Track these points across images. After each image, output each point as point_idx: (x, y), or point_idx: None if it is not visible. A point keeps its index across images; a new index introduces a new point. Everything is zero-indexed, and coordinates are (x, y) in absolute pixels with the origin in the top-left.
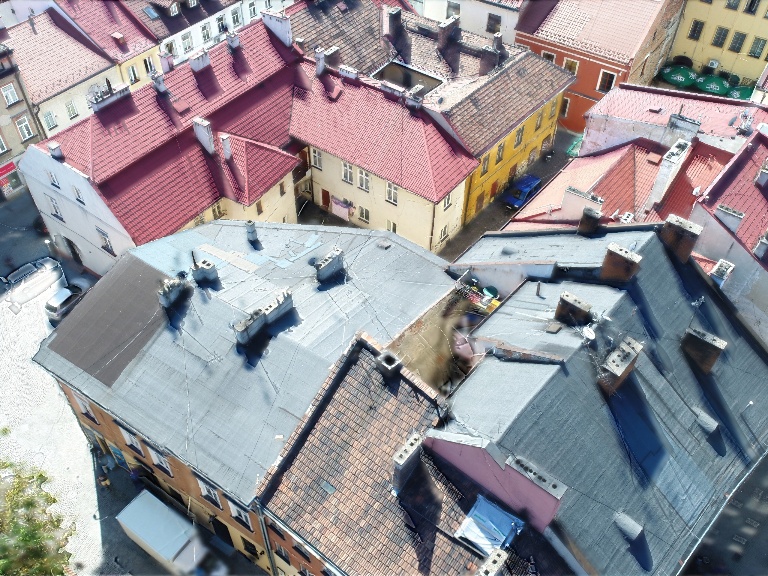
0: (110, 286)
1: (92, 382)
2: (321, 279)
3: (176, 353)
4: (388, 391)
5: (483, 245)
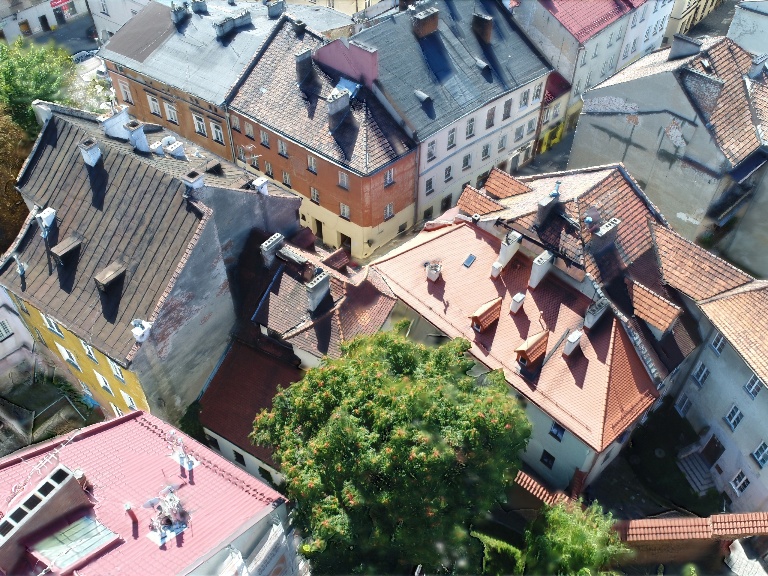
0: (142, 17)
1: (132, 61)
2: (271, 15)
3: (181, 44)
4: (298, 39)
5: None
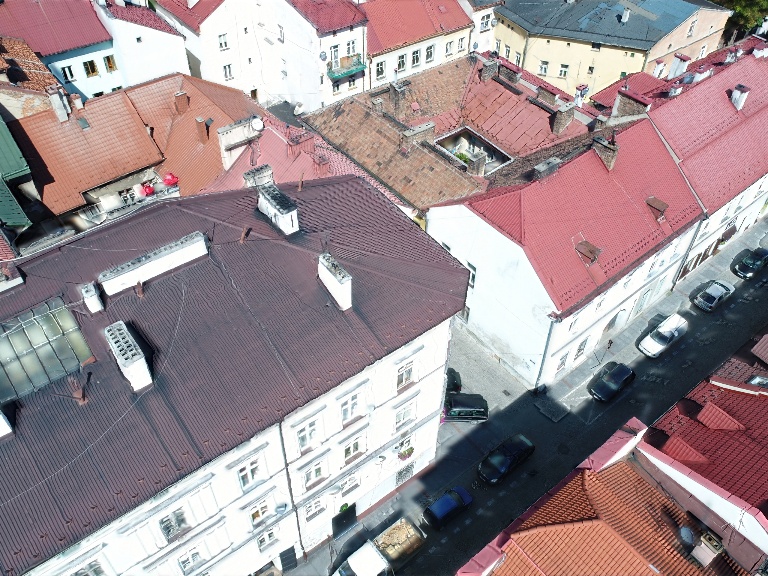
0: (704, 5)
1: None
2: None
3: None
4: None
5: (480, 1)
